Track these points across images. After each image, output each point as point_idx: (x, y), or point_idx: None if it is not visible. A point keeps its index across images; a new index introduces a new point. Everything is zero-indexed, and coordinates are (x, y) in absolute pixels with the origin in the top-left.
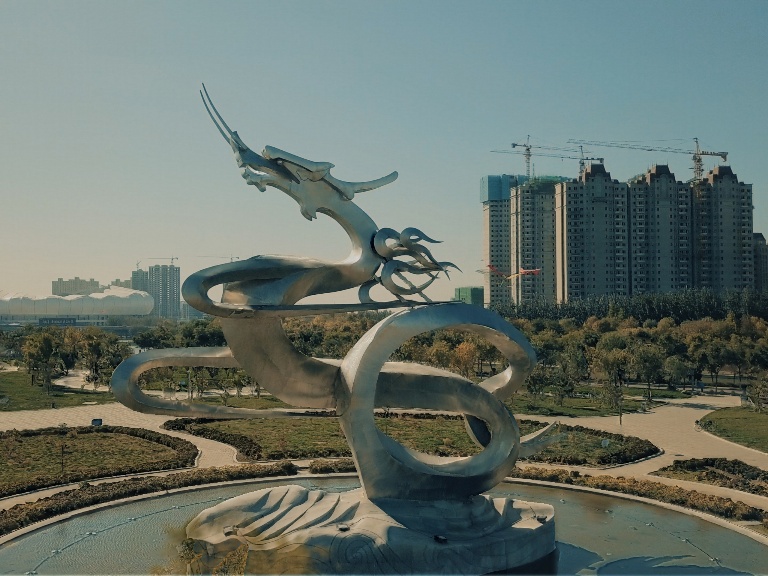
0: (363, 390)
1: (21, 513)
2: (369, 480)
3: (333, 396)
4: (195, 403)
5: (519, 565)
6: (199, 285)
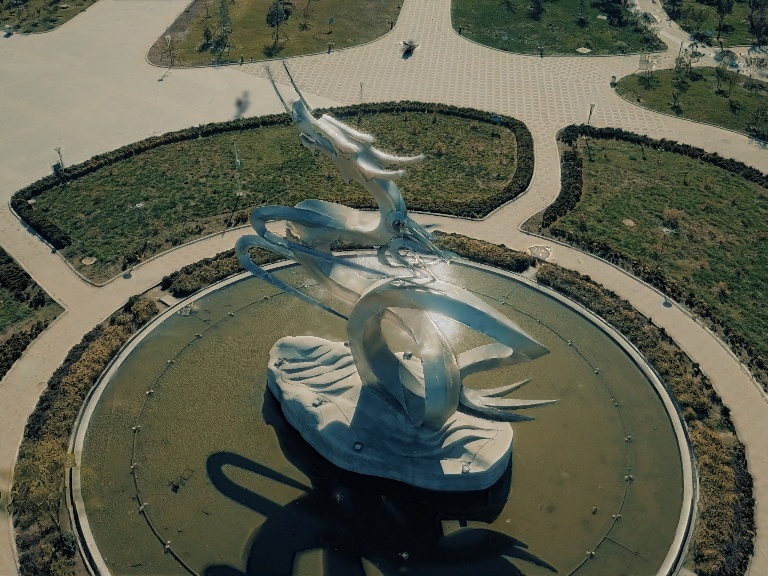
0: (356, 325)
1: None
2: (363, 377)
3: None
4: None
5: (425, 487)
6: (256, 220)
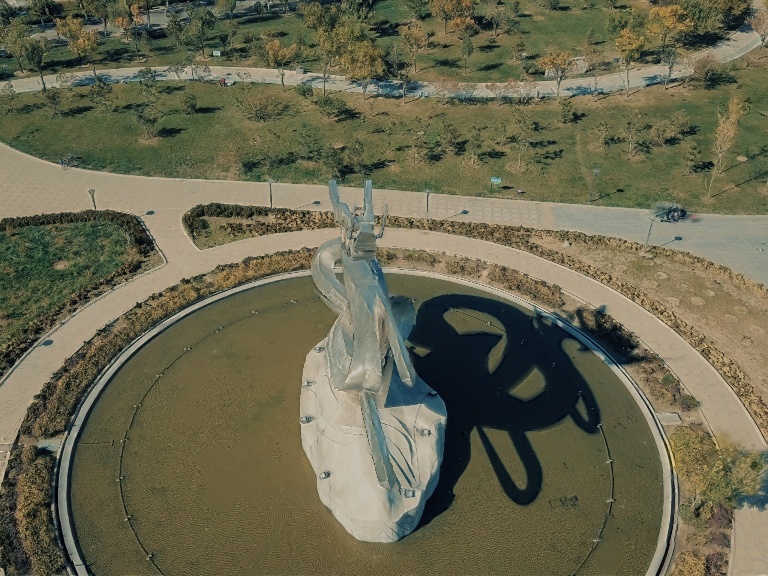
0: None
1: None
2: None
3: None
4: None
5: None
6: None
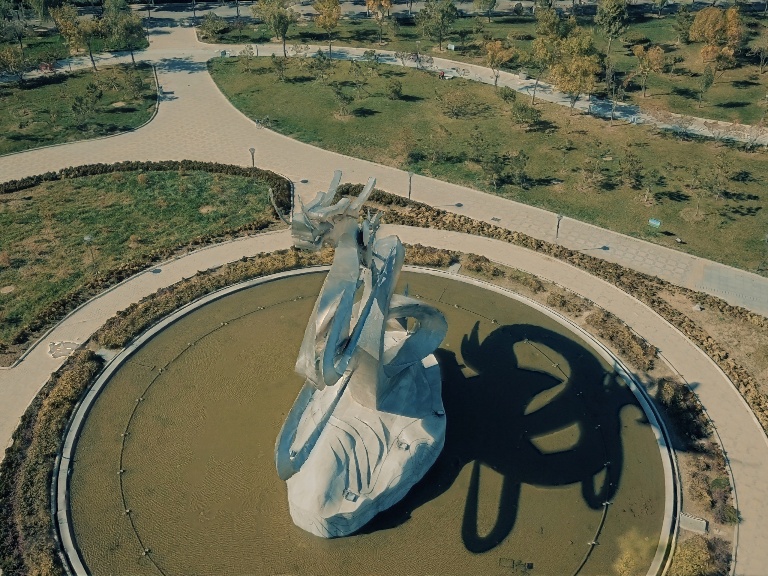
0: None
1: None
2: None
3: None
4: (310, 439)
5: None
6: (334, 370)
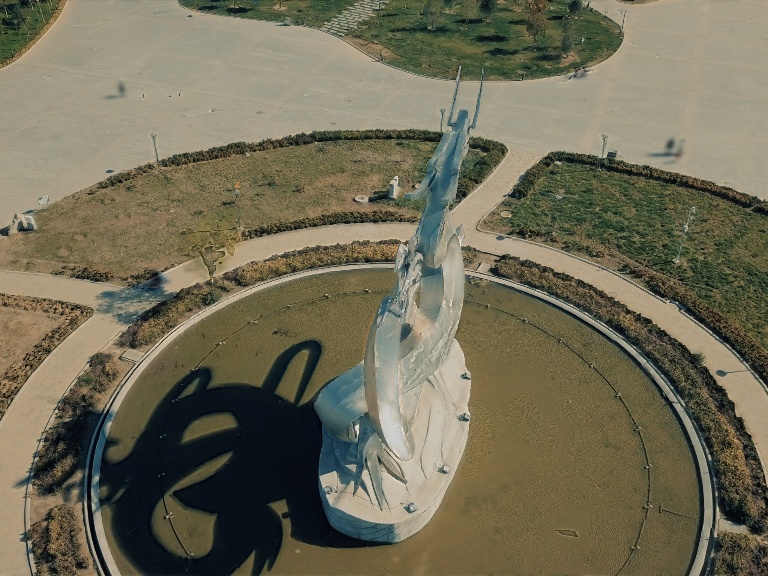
0: None
1: None
2: None
3: None
4: None
5: None
6: None
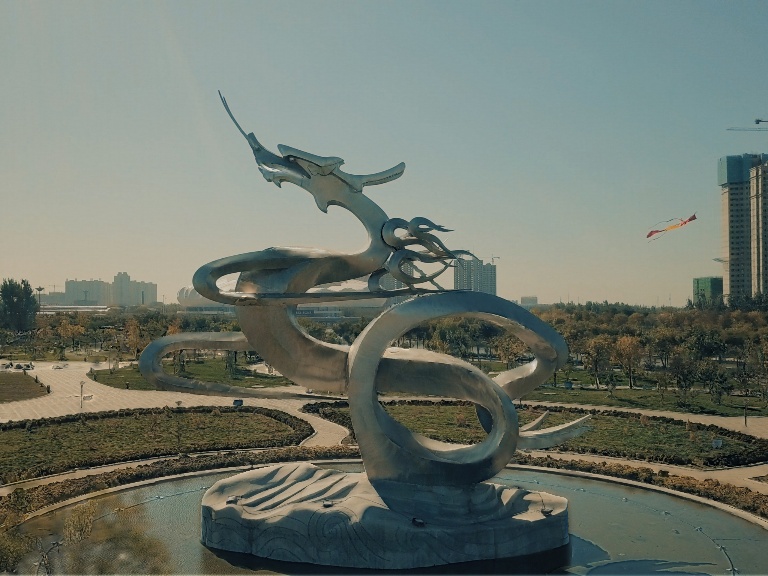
0: (362, 375)
1: (114, 476)
2: (369, 462)
3: (346, 380)
4: None
5: (511, 556)
6: (206, 275)
